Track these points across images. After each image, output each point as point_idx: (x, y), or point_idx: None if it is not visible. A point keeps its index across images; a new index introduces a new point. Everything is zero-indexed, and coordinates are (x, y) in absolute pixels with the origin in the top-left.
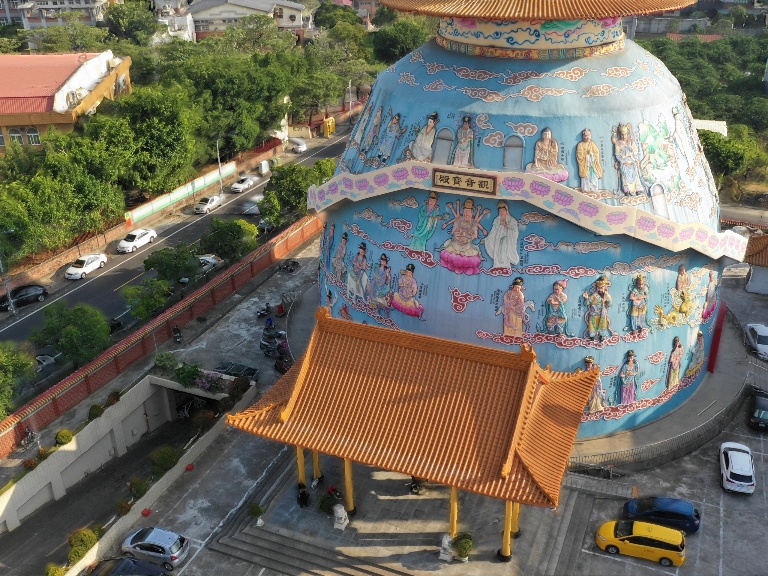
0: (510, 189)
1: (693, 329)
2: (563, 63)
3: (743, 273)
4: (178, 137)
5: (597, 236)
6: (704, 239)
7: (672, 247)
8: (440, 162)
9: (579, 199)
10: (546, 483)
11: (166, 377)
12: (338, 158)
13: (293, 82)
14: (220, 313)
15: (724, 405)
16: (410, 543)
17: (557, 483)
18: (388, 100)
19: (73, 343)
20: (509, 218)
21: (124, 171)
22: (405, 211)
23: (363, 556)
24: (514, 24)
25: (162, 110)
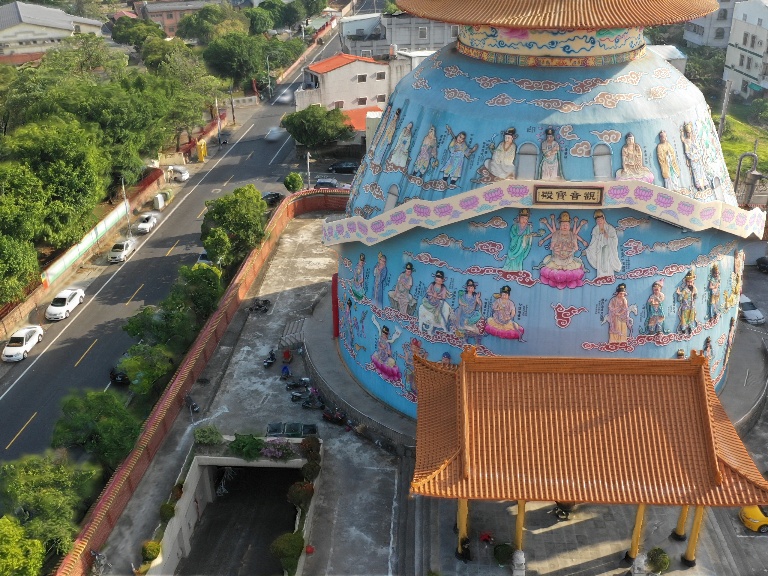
0: (615, 198)
1: (737, 307)
2: (619, 68)
3: None
4: (89, 180)
5: (684, 233)
6: (759, 223)
7: (744, 234)
8: (526, 178)
9: (678, 200)
10: (756, 481)
11: (217, 454)
12: (230, 183)
13: (168, 106)
14: (219, 370)
15: (759, 372)
16: (596, 572)
17: (762, 478)
18: (442, 119)
19: (111, 438)
20: (607, 226)
21: (37, 226)
22: (492, 232)
23: None
24: (571, 32)
25: (67, 151)
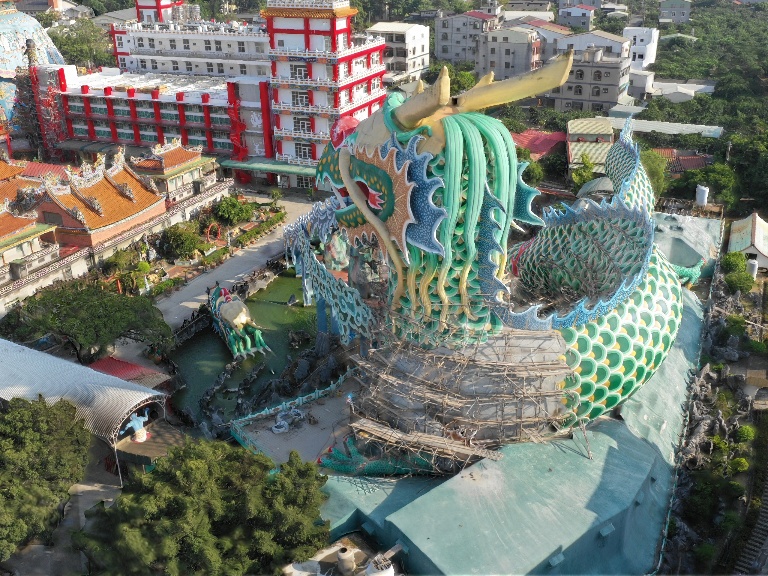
0: None
1: (10, 103)
2: None
3: None
4: None
5: None
6: None
7: None
8: None
9: None
10: None
11: None
12: None
13: None
14: None
15: None
16: None
17: None
18: None
19: None
20: None
21: None
22: None
23: None
24: None
25: None
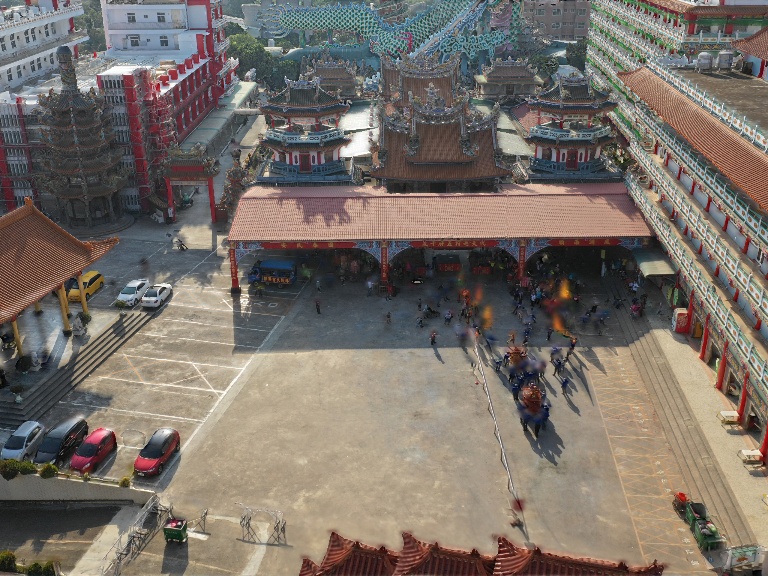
0: None
1: None
2: None
3: None
4: None
5: None
6: None
7: None
8: None
9: None
10: None
11: None
12: None
13: None
14: None
15: None
16: (65, 344)
17: None
18: None
19: None
20: None
21: None
22: None
23: (70, 359)
24: None
25: None
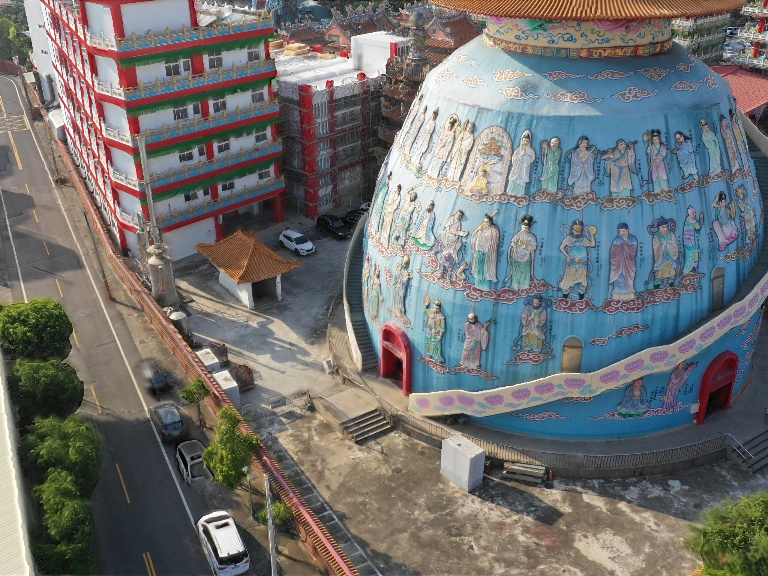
0: None
1: None
2: None
3: (244, 314)
4: None
5: None
6: None
7: None
8: None
9: None
10: None
11: None
12: None
13: None
14: None
15: None
16: None
17: None
18: None
19: None
20: None
21: None
22: None
23: None
24: None
25: None
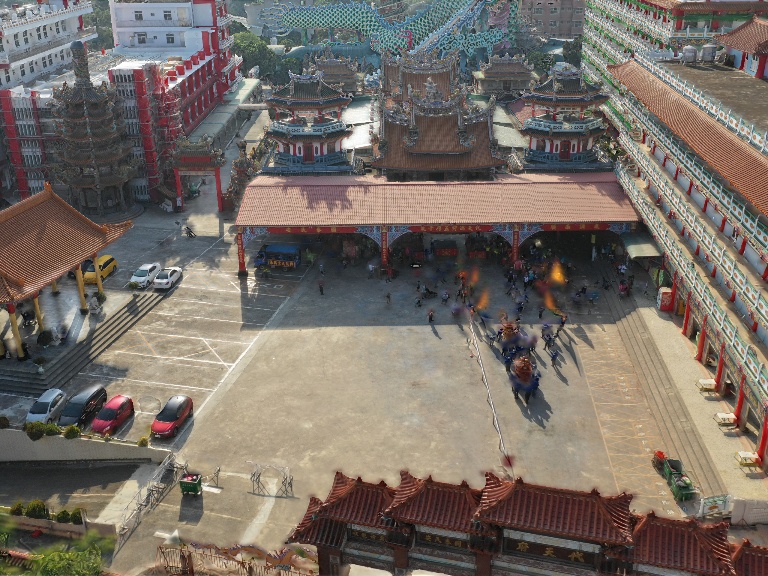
0: None
1: None
2: None
3: None
4: None
5: None
6: None
7: None
8: None
9: None
10: None
11: None
12: None
13: None
14: None
15: None
16: (82, 322)
17: None
18: None
19: None
20: None
21: None
22: None
23: (88, 334)
24: None
25: None
